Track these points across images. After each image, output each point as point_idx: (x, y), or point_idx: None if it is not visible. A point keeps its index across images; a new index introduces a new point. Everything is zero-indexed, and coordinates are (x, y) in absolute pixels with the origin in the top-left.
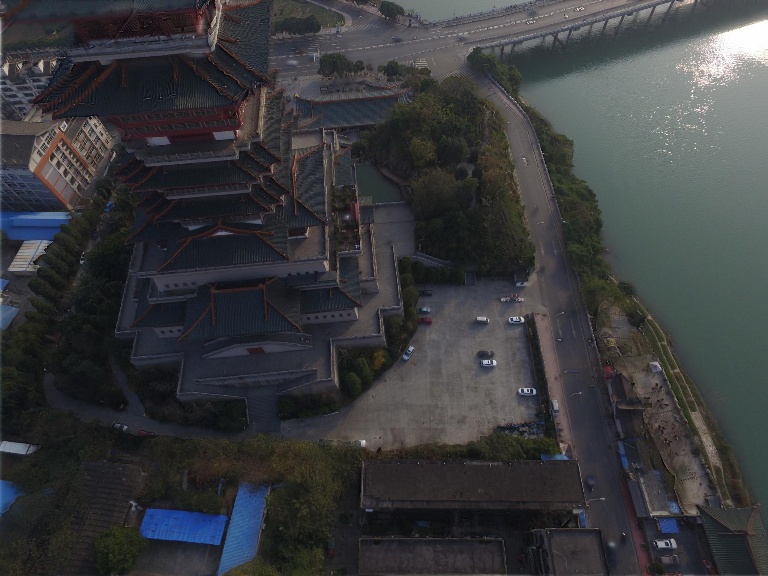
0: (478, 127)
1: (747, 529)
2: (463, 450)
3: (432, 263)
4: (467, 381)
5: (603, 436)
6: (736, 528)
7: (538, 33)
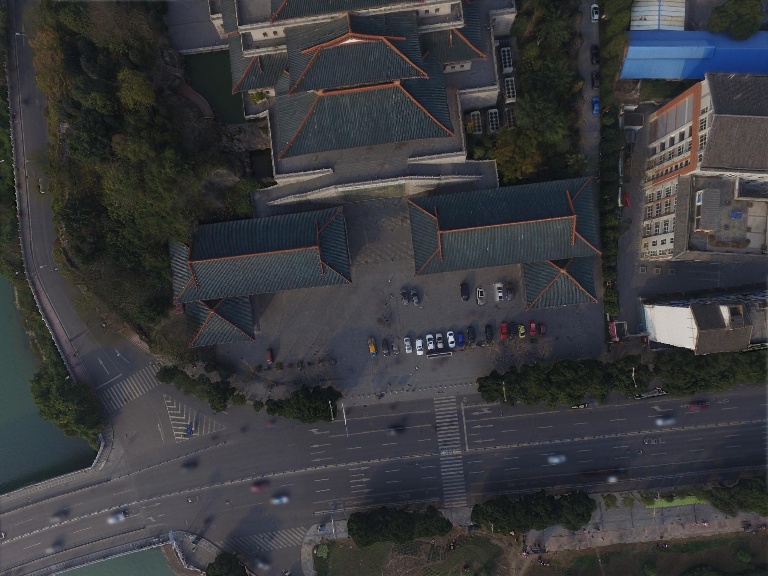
0: None
1: None
2: None
3: None
4: None
5: None
6: None
7: None
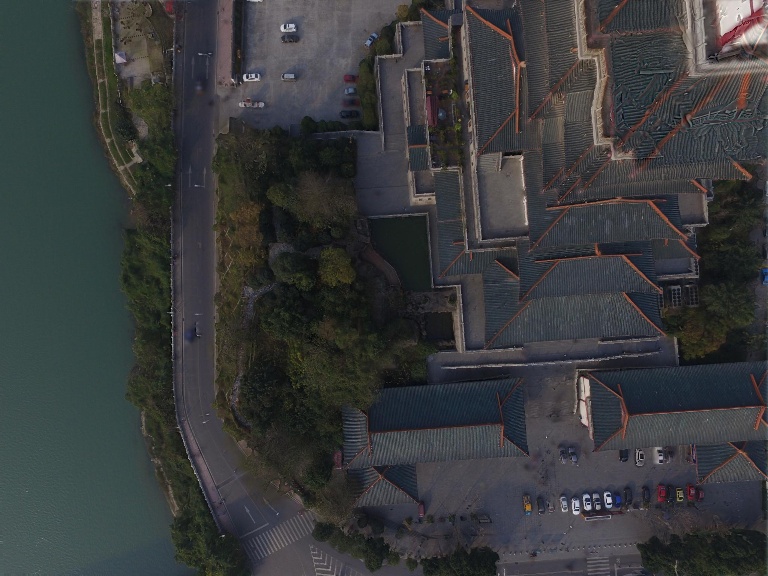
0: None
1: None
2: None
3: (338, 133)
4: (313, 12)
5: None
6: None
7: None
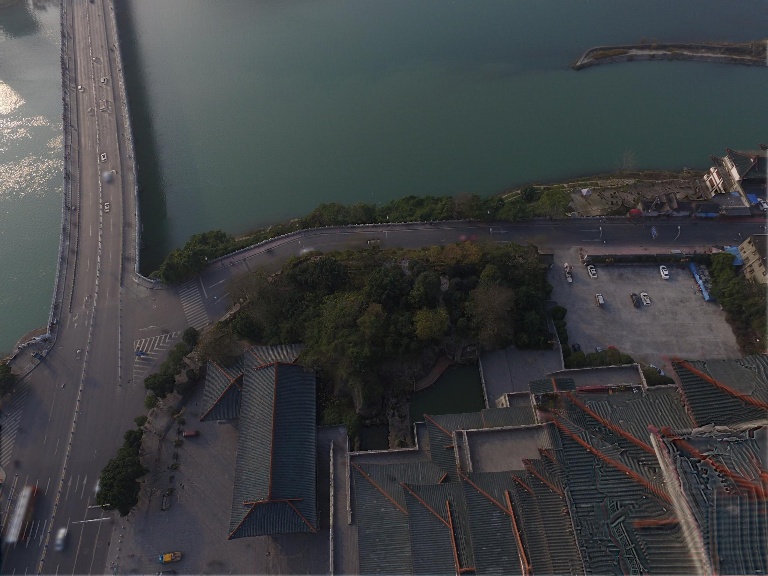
0: (348, 271)
1: (749, 157)
2: (767, 318)
3: None
4: (668, 319)
5: (687, 226)
6: (750, 162)
7: (134, 203)
